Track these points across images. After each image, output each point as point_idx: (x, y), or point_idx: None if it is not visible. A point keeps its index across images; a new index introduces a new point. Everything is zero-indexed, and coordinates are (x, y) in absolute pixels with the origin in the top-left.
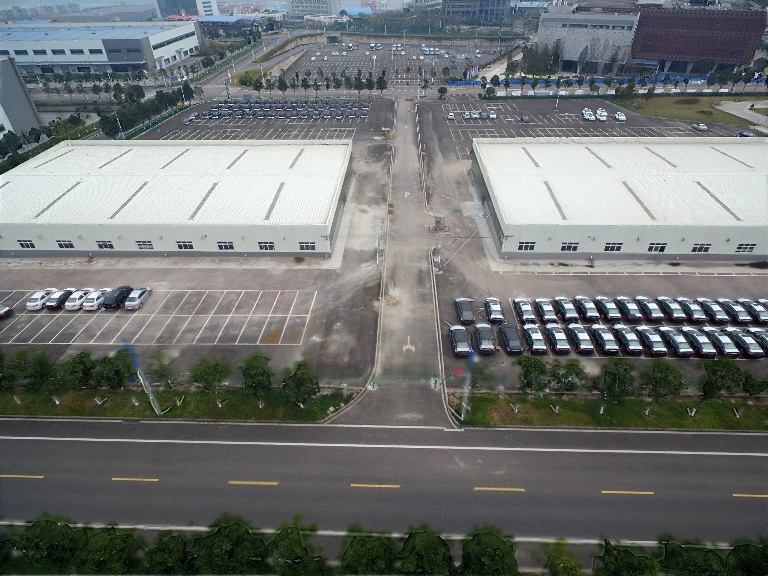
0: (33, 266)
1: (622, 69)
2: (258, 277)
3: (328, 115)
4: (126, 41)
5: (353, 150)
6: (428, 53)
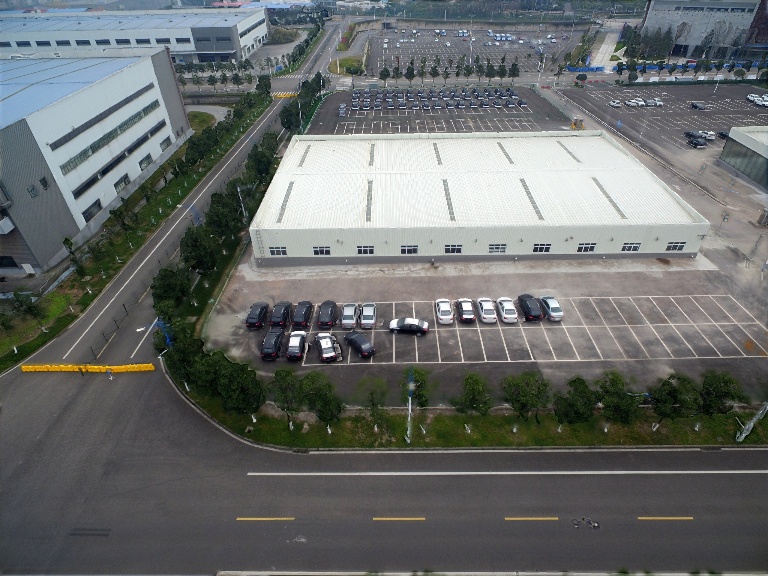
0: (378, 274)
1: (736, 53)
2: (645, 281)
3: (487, 104)
4: (216, 29)
5: None
6: (500, 39)
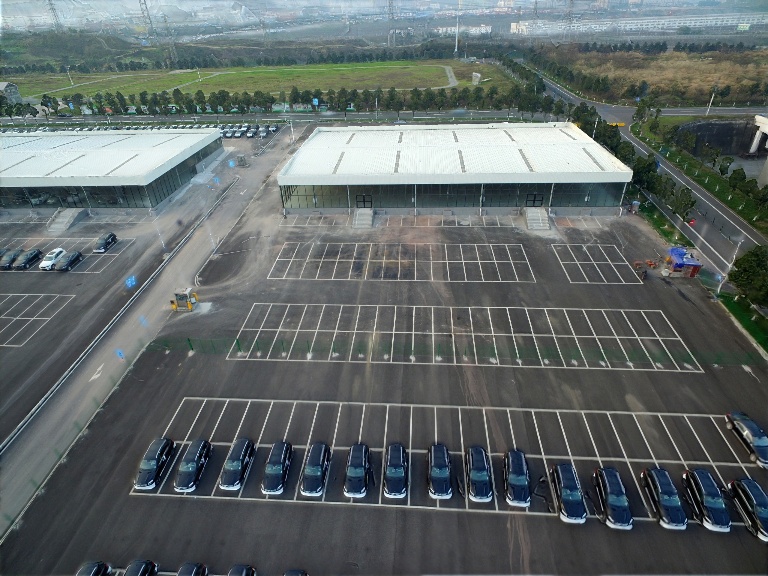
0: None
1: None
2: None
3: None
4: None
5: (267, 262)
6: None
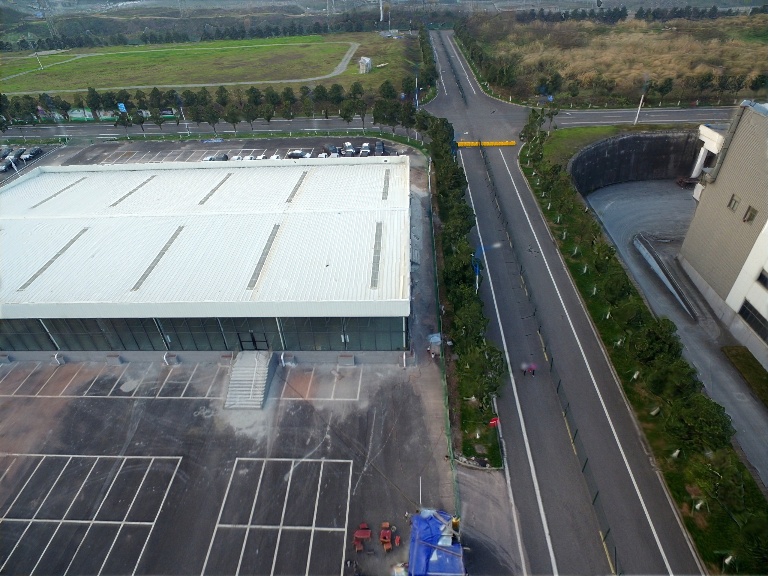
0: None
1: None
2: None
3: None
4: None
5: None
6: None
